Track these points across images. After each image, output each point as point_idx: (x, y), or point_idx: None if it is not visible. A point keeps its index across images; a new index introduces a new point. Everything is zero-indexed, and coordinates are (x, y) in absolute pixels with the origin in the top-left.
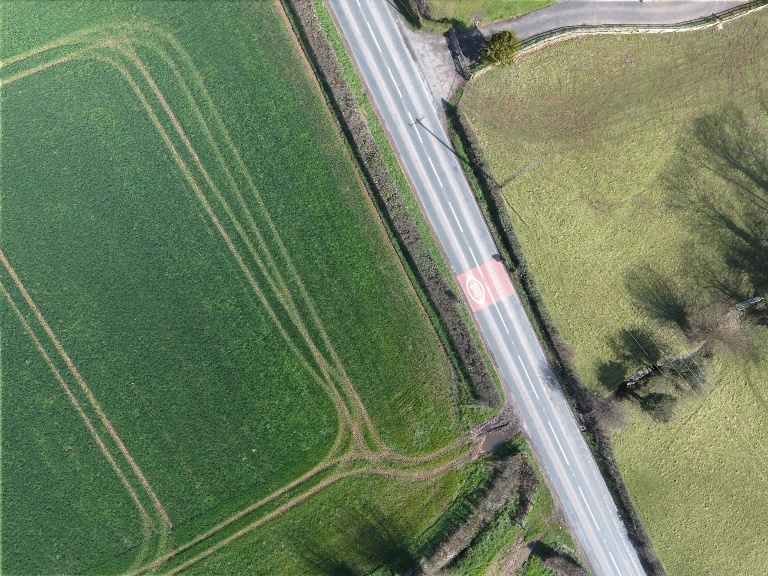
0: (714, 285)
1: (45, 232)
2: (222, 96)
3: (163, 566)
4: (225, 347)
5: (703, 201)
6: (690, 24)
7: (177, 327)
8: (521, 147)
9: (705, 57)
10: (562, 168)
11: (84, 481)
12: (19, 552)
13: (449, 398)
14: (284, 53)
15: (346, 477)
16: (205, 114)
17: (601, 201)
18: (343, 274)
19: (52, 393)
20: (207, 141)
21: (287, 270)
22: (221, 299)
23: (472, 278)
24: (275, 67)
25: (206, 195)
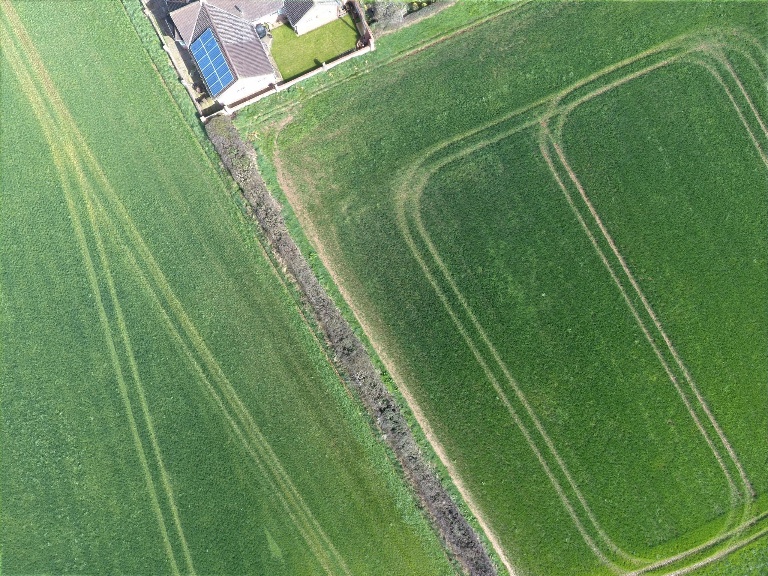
0: None
1: (651, 222)
2: None
3: (747, 531)
4: None
5: None
6: None
7: (762, 310)
8: None
9: None
10: None
11: (682, 452)
12: (626, 516)
13: None
14: None
15: None
16: None
17: None
18: None
19: (655, 371)
20: None
21: None
22: None
23: None
24: None
25: None
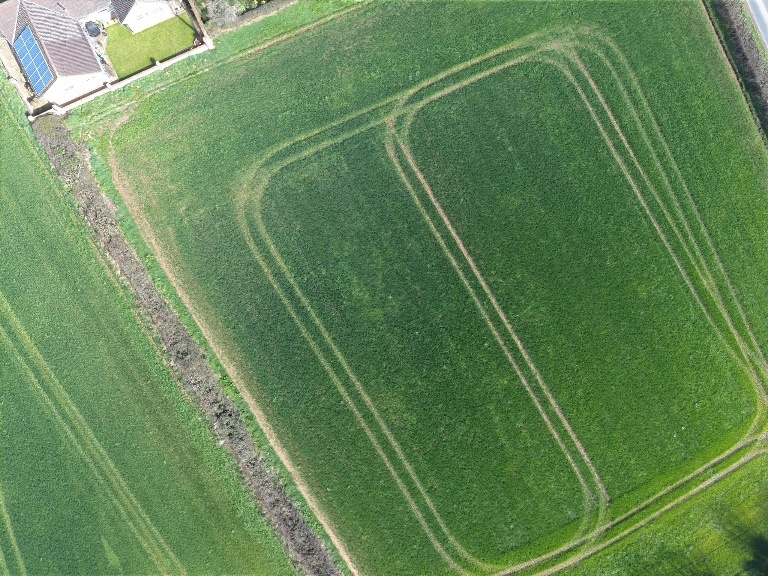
0: None
1: (501, 224)
2: (656, 95)
3: (602, 536)
4: (658, 331)
5: None
6: None
7: (616, 312)
8: None
9: None
10: None
11: (534, 456)
12: (477, 522)
13: None
14: (710, 55)
15: (762, 454)
16: (641, 112)
17: None
18: (762, 263)
19: (506, 374)
20: (642, 138)
21: (713, 259)
22: (655, 286)
23: None
24: (702, 68)
25: (642, 189)
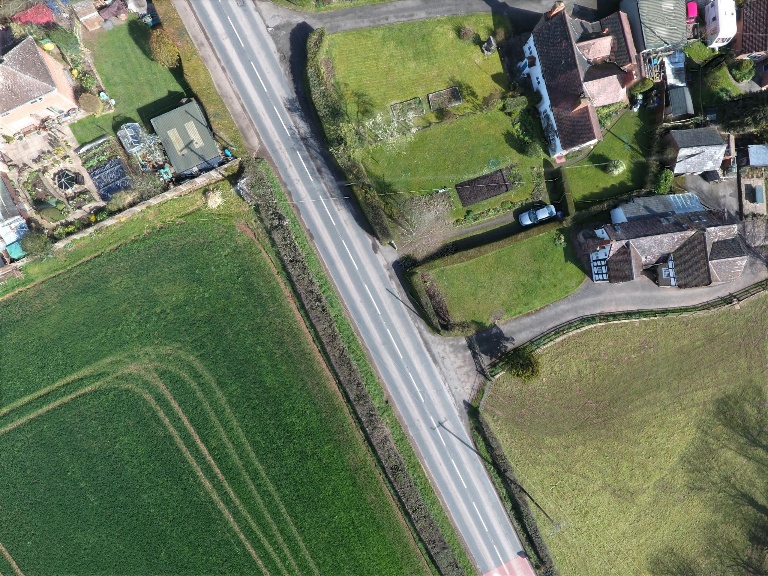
0: (737, 563)
1: (75, 565)
2: (246, 415)
3: None
4: None
5: (725, 481)
6: (707, 305)
7: None
8: (543, 442)
9: (723, 337)
10: (584, 459)
11: None
12: None
13: None
14: (306, 367)
15: None
16: (229, 434)
17: (624, 489)
18: None
19: None
20: (232, 461)
21: None
22: None
23: None
24: (297, 382)
25: (233, 515)
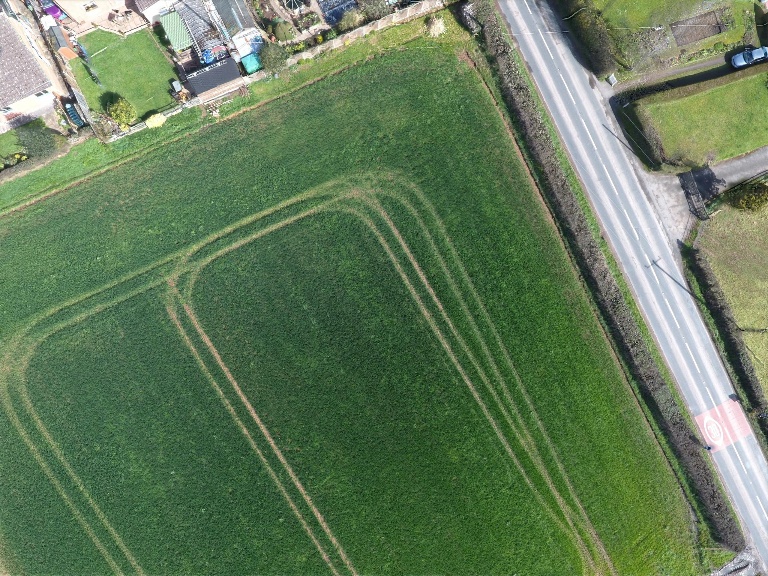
0: None
1: (296, 388)
2: (465, 244)
3: None
4: (472, 498)
5: None
6: None
7: (425, 479)
8: (754, 285)
9: None
10: None
11: None
12: None
13: (689, 540)
14: (524, 199)
15: None
16: (449, 263)
17: None
18: (585, 419)
19: (304, 550)
20: (451, 290)
21: (531, 417)
22: (467, 449)
23: (710, 419)
24: (516, 213)
25: (451, 345)
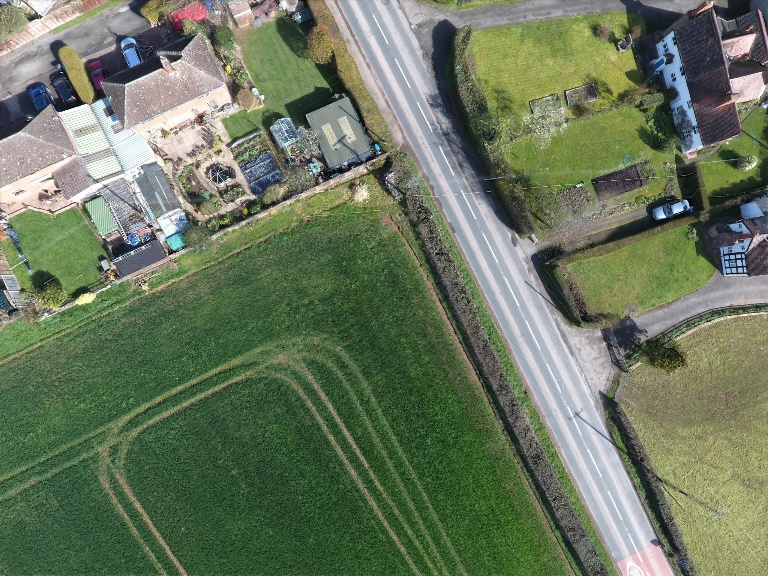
0: None
1: (226, 550)
2: (390, 405)
3: None
4: None
5: None
6: None
7: None
8: (676, 433)
9: None
10: (715, 450)
11: None
12: None
13: None
14: (448, 358)
15: None
16: (375, 423)
17: (752, 479)
18: (509, 569)
19: None
20: (377, 450)
21: (456, 570)
22: None
23: (632, 564)
24: (440, 372)
25: (378, 502)
